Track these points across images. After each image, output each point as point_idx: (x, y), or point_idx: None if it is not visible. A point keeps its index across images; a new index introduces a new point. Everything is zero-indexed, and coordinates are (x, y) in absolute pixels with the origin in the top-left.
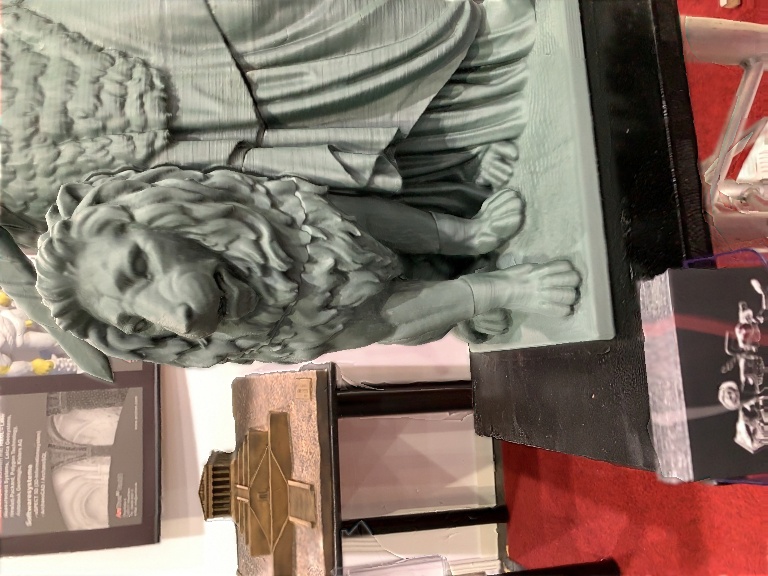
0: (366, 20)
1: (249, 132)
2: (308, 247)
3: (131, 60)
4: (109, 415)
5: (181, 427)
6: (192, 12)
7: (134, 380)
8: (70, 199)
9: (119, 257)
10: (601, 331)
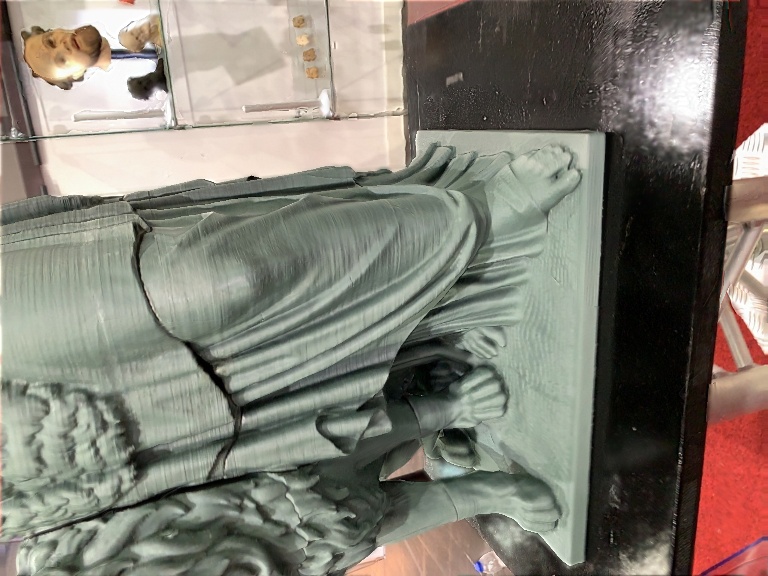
0: (357, 281)
1: (225, 429)
2: (305, 549)
3: (70, 400)
4: None
5: None
6: (143, 339)
7: None
8: None
9: None
10: (574, 562)
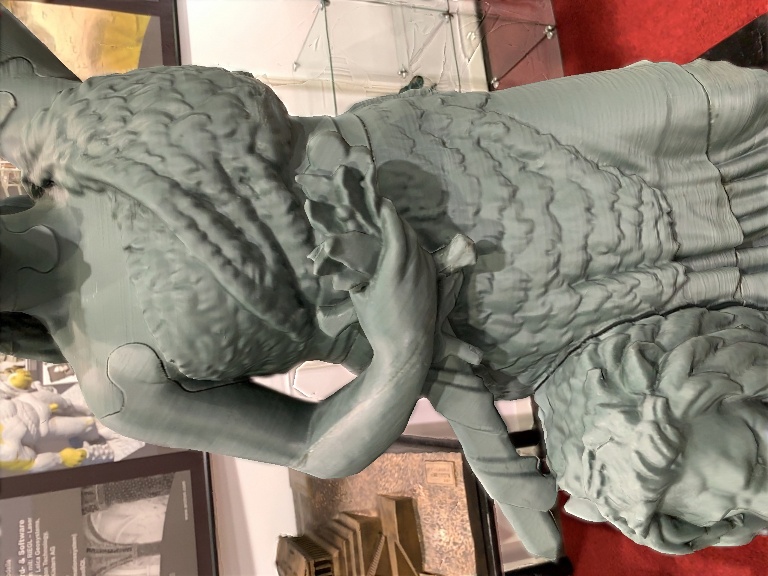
0: None
1: (731, 256)
2: None
3: (635, 179)
4: (155, 506)
5: (231, 510)
6: (695, 122)
7: (180, 463)
8: (651, 366)
9: (743, 442)
10: None
